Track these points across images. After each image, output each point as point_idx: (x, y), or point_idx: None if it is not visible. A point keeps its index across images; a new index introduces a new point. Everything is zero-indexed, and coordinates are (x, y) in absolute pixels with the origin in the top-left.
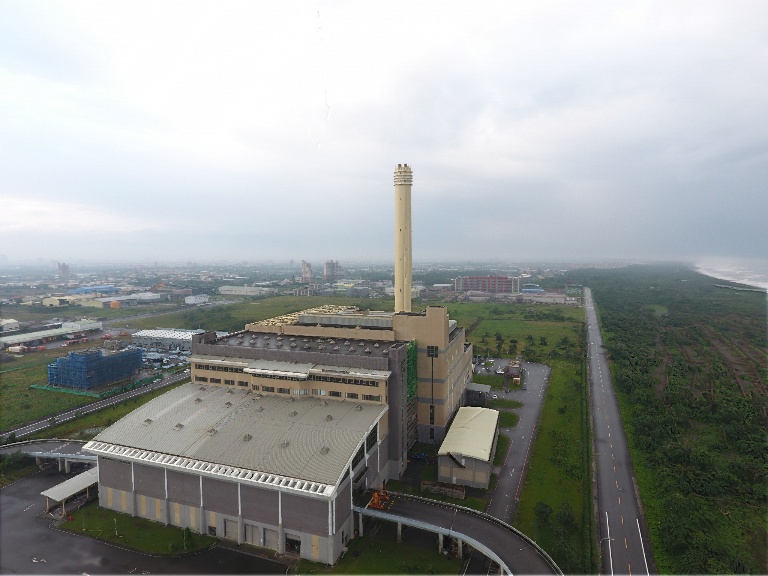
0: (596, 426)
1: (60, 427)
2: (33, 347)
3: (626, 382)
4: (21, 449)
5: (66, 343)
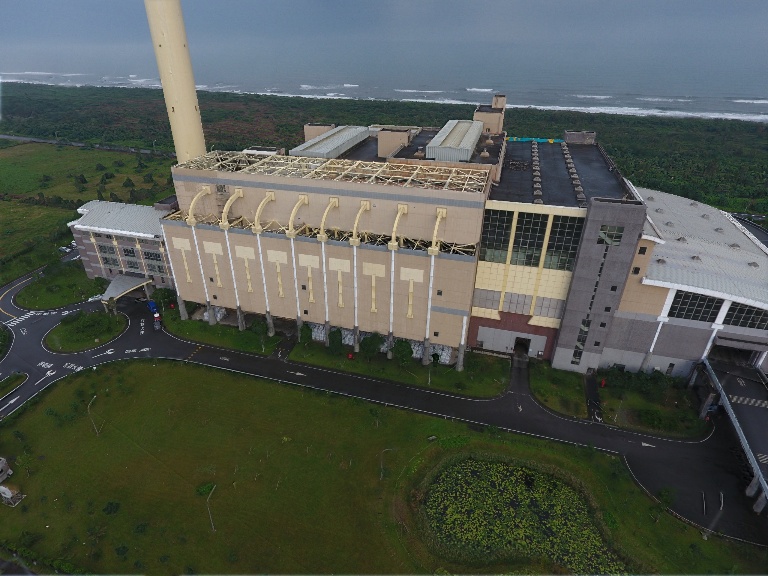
0: None
1: None
2: None
3: None
4: None
5: None
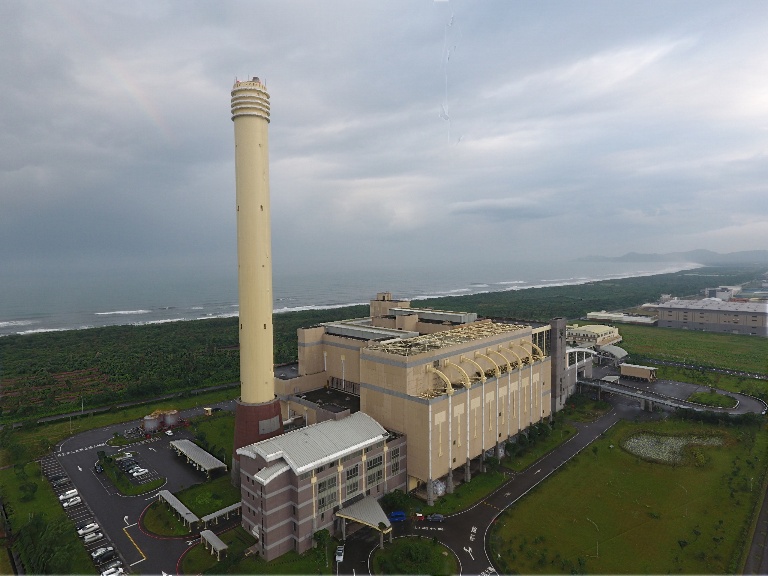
0: None
1: None
2: None
3: (156, 384)
4: (712, 410)
5: None
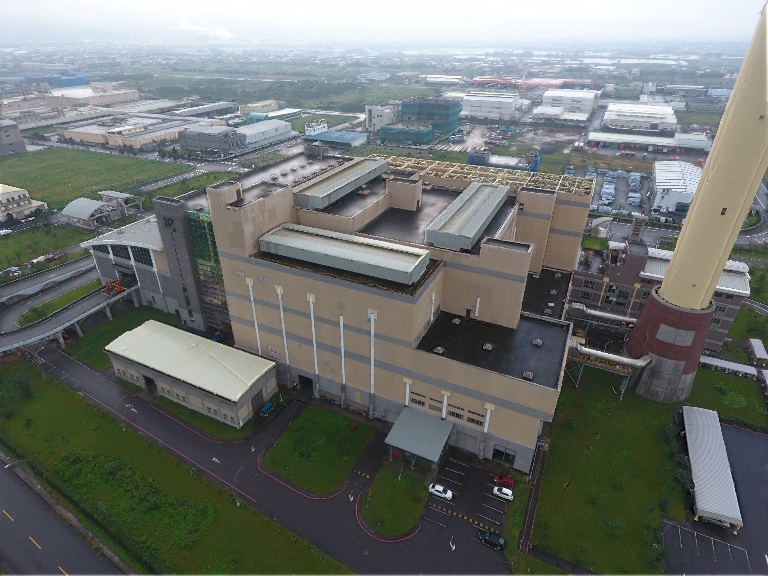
0: None
1: None
2: (587, 147)
3: None
4: None
5: (620, 153)
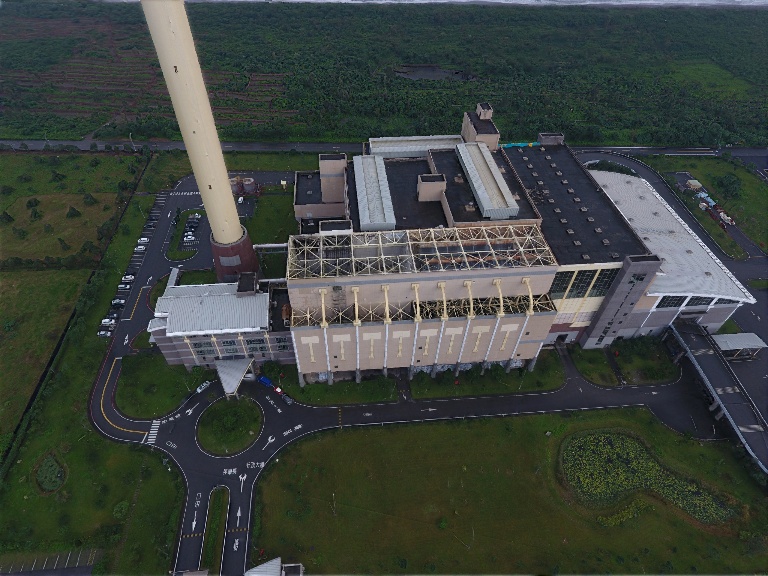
0: None
1: (735, 568)
2: None
3: (281, 129)
4: None
5: None
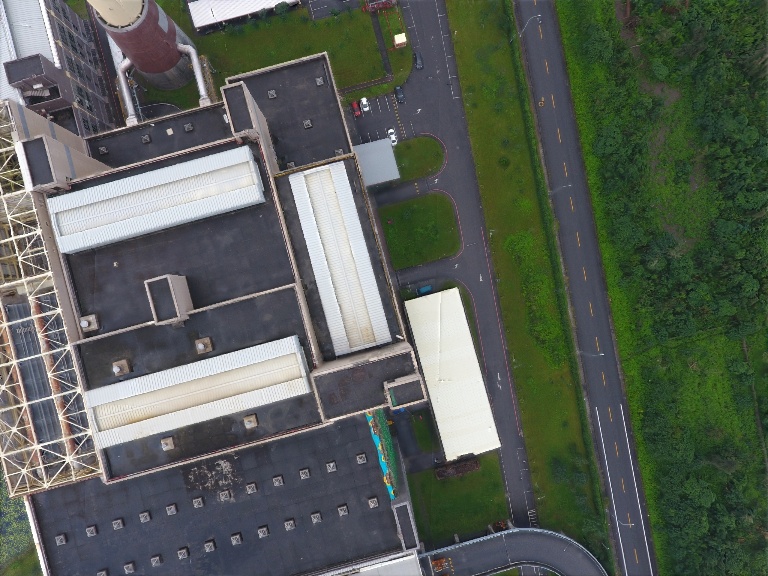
0: (552, 181)
1: None
2: None
3: None
4: None
5: None
